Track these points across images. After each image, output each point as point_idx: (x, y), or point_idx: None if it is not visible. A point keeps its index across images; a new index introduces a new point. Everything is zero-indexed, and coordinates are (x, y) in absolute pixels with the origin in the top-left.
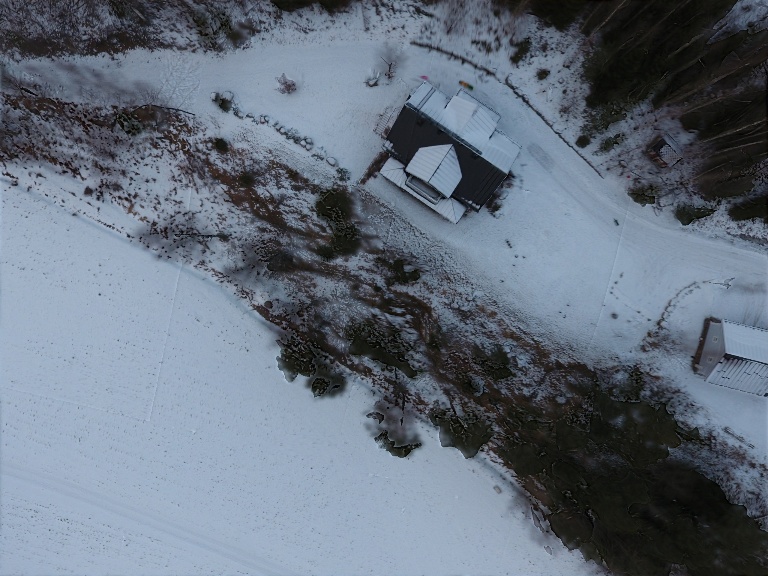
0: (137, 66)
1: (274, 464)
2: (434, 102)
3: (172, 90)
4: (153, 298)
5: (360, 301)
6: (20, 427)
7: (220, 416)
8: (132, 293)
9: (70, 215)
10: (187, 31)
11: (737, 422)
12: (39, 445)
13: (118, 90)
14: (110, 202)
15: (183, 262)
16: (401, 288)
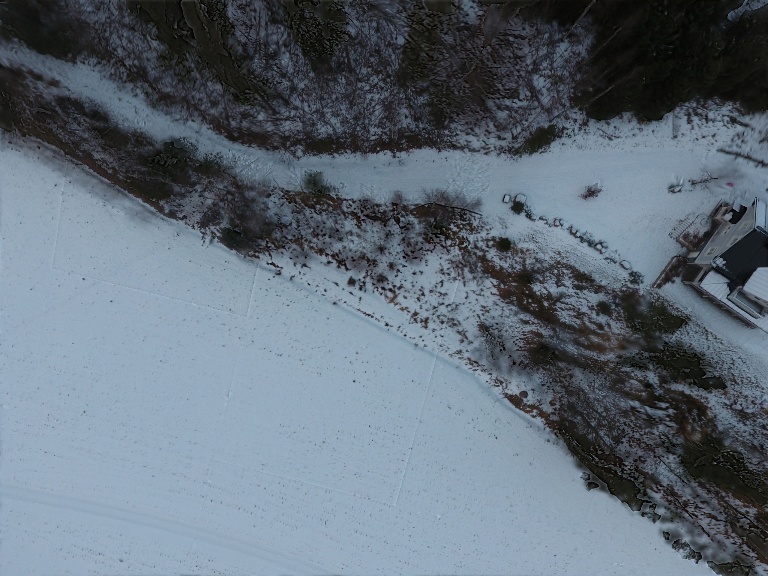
0: (422, 165)
1: (517, 551)
2: None
3: (459, 190)
4: (407, 386)
5: (619, 393)
6: (268, 509)
7: (466, 502)
8: (387, 380)
9: (331, 304)
10: (485, 135)
11: None
12: (286, 527)
13: (400, 188)
14: (372, 292)
15: (439, 351)
16: (676, 386)
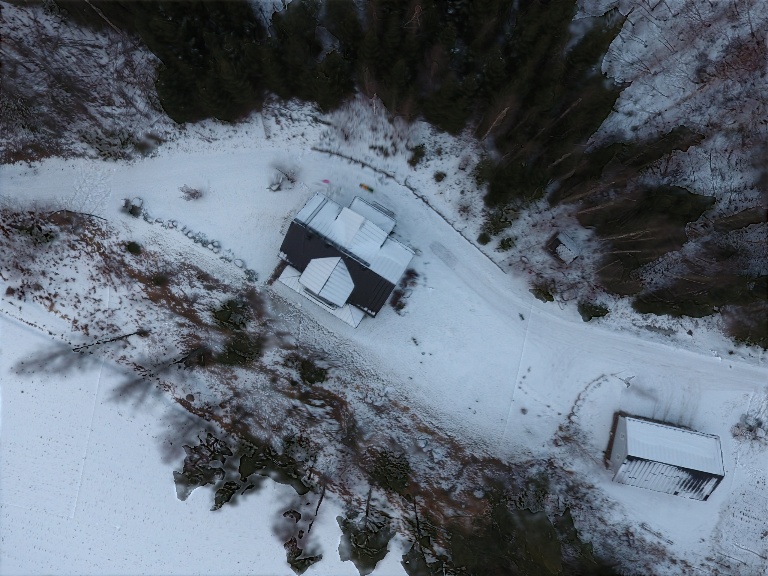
0: (52, 174)
1: (200, 559)
2: (325, 214)
3: (85, 196)
4: (75, 394)
5: (281, 392)
6: None
7: (145, 511)
8: (54, 390)
9: None
10: (97, 142)
11: (654, 518)
12: None
13: (34, 197)
14: (32, 301)
15: (105, 357)
16: None
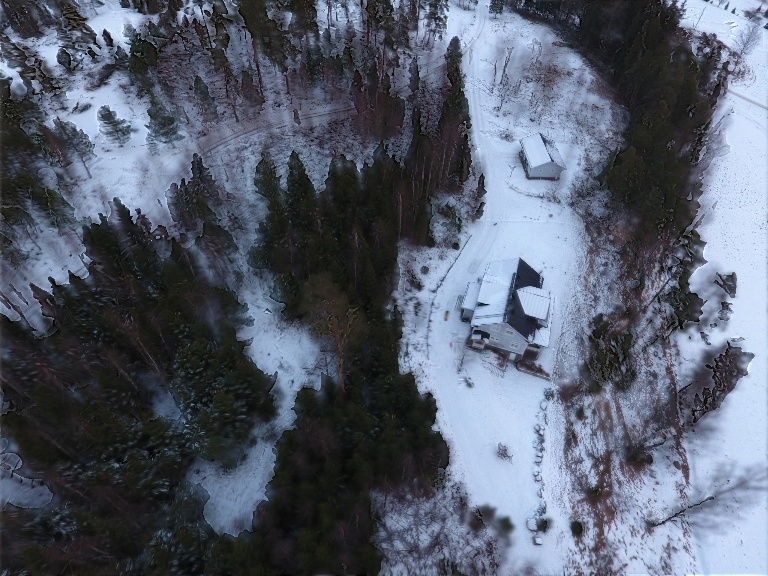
0: None
1: None
2: (488, 312)
3: None
4: None
5: None
6: None
7: None
8: None
9: None
10: None
11: (572, 162)
12: None
13: None
14: None
15: (700, 575)
16: (601, 344)
